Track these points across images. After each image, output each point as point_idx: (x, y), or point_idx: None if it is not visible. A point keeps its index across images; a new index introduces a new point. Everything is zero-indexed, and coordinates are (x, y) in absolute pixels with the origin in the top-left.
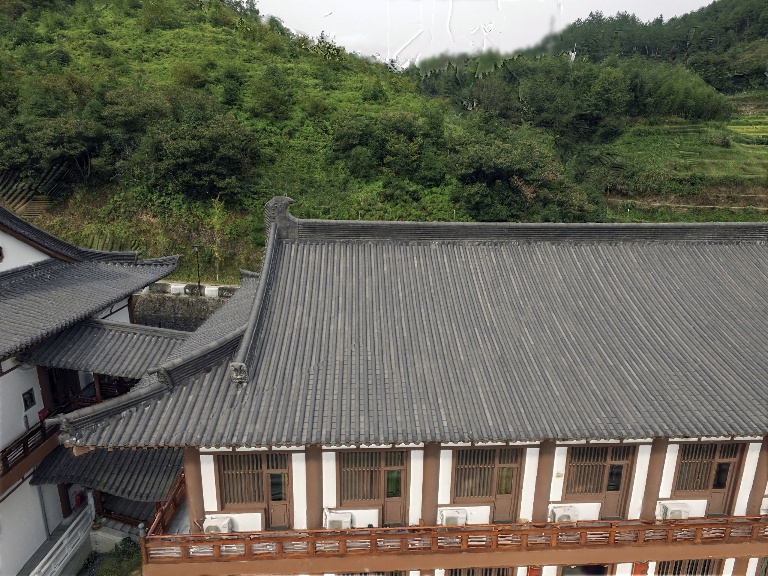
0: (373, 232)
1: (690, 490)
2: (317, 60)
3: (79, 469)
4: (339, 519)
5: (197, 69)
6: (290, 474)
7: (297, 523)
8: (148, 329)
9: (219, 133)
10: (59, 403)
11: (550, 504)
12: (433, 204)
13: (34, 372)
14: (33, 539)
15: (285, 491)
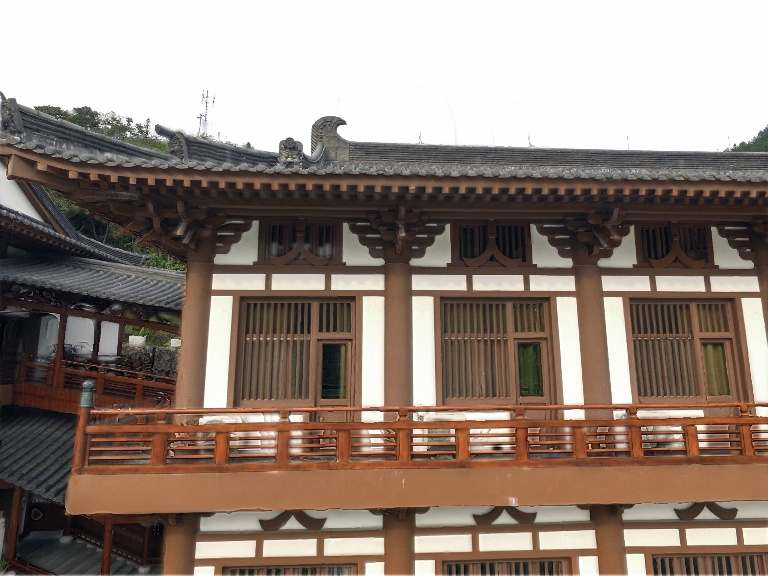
0: (437, 155)
1: None
2: None
3: None
4: (445, 417)
5: None
6: (358, 335)
7: None
8: (147, 271)
9: None
10: None
11: None
12: None
13: None
14: None
15: (346, 379)
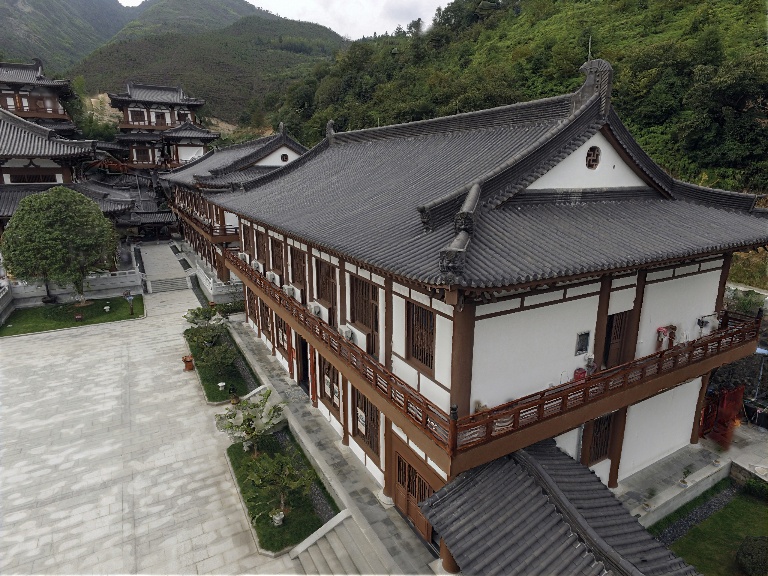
0: (351, 138)
1: (326, 300)
2: (659, 4)
3: None
4: None
5: (530, 48)
6: None
7: None
8: None
9: (465, 97)
10: None
11: (289, 283)
12: (647, 146)
13: None
14: None
15: None
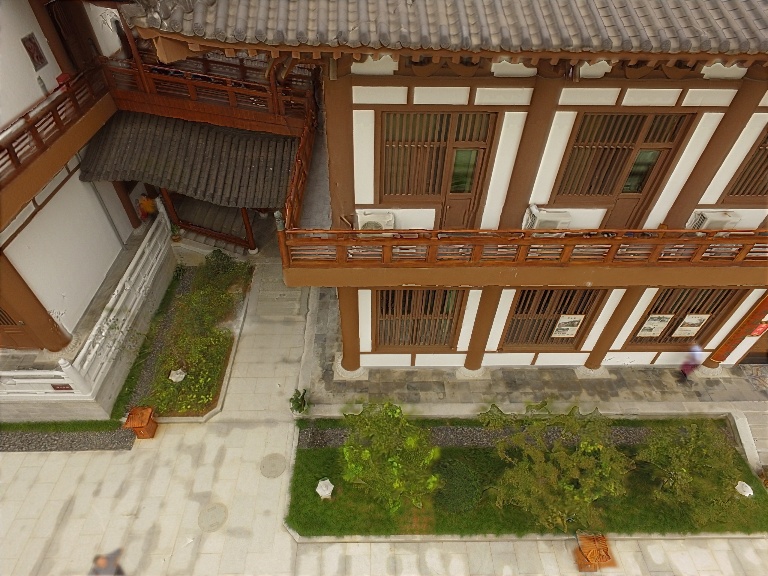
0: None
1: None
2: None
3: (139, 164)
4: (555, 219)
5: None
6: (493, 149)
7: (485, 225)
8: None
9: None
10: (81, 70)
11: None
12: None
13: (26, 5)
14: (107, 247)
15: (473, 179)
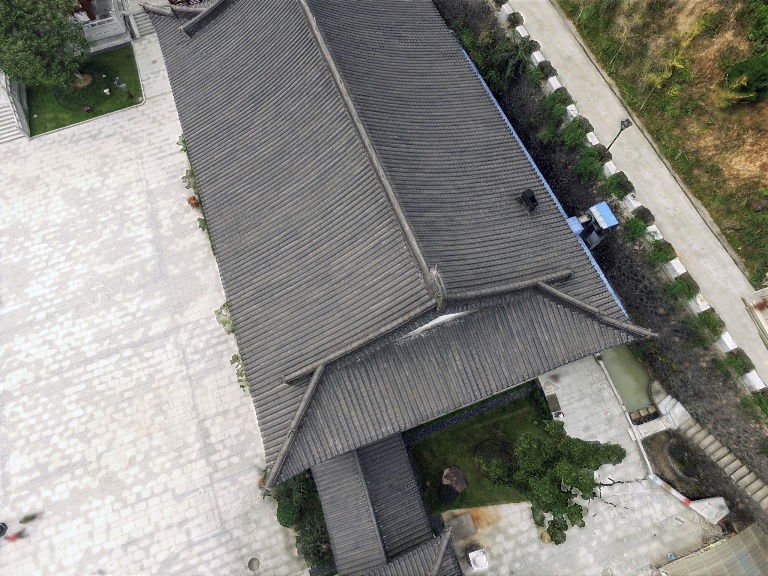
0: None
1: None
2: None
3: None
4: None
5: None
6: None
7: None
8: None
9: None
10: None
11: None
12: None
13: None
14: None
15: None
